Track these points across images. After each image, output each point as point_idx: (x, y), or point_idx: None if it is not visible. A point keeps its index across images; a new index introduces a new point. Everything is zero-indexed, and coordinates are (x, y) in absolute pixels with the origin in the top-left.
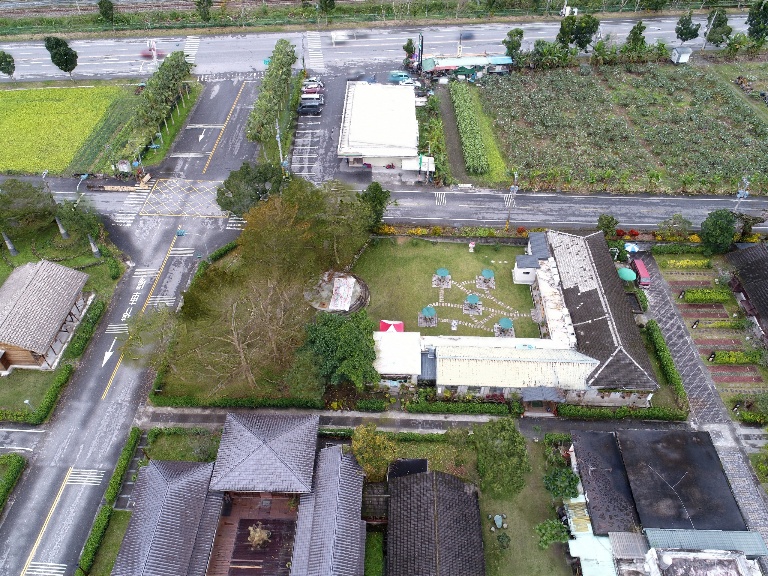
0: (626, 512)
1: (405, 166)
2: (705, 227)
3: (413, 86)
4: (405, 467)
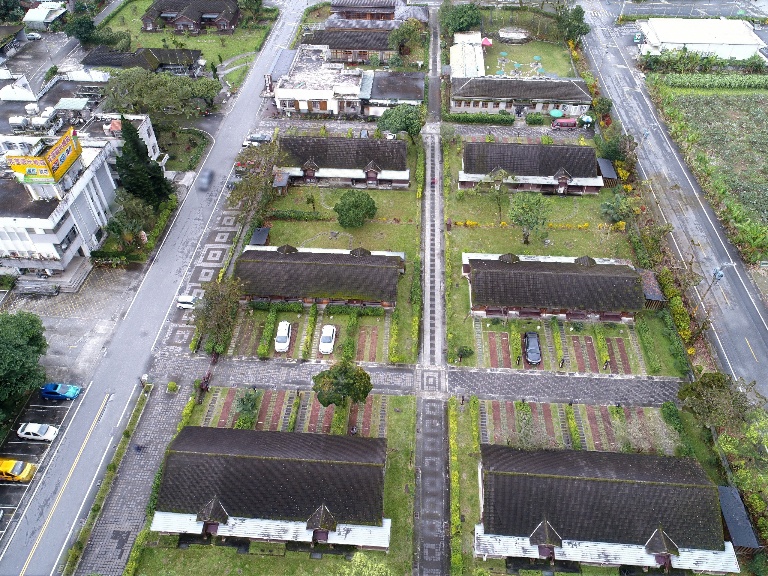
0: None
1: None
2: None
3: (765, 45)
4: (406, 40)
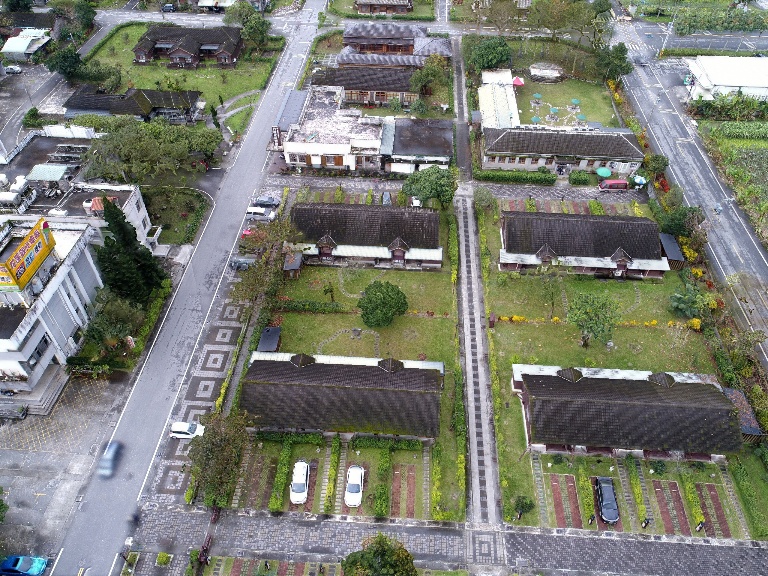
0: None
1: None
2: None
3: None
4: None
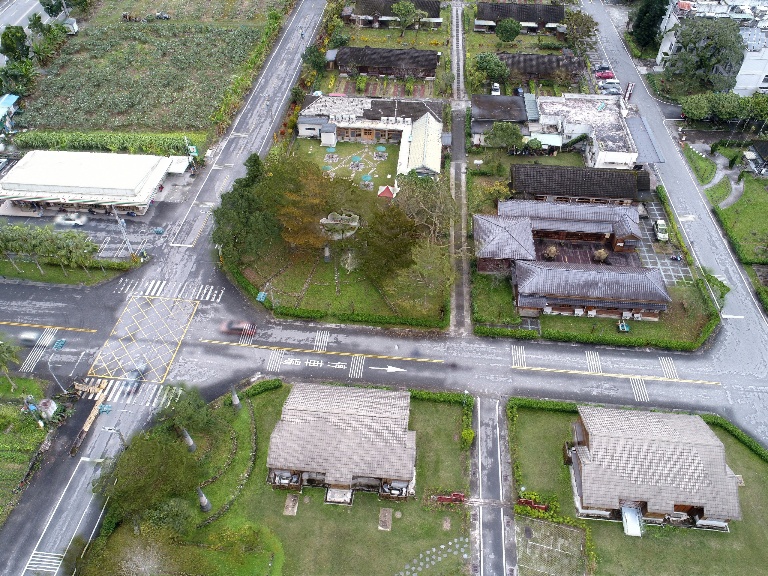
0: None
1: (179, 171)
2: (313, 62)
3: None
4: None
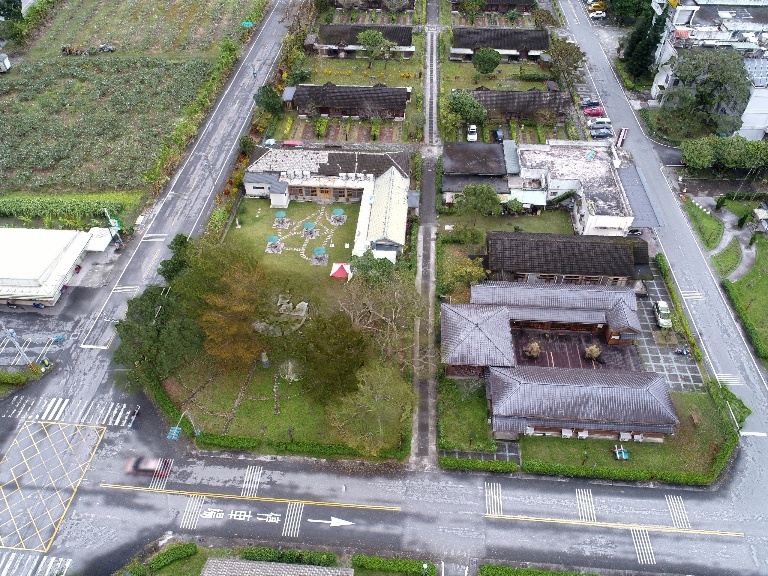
0: (495, 180)
1: (99, 248)
2: (266, 104)
3: None
4: None
